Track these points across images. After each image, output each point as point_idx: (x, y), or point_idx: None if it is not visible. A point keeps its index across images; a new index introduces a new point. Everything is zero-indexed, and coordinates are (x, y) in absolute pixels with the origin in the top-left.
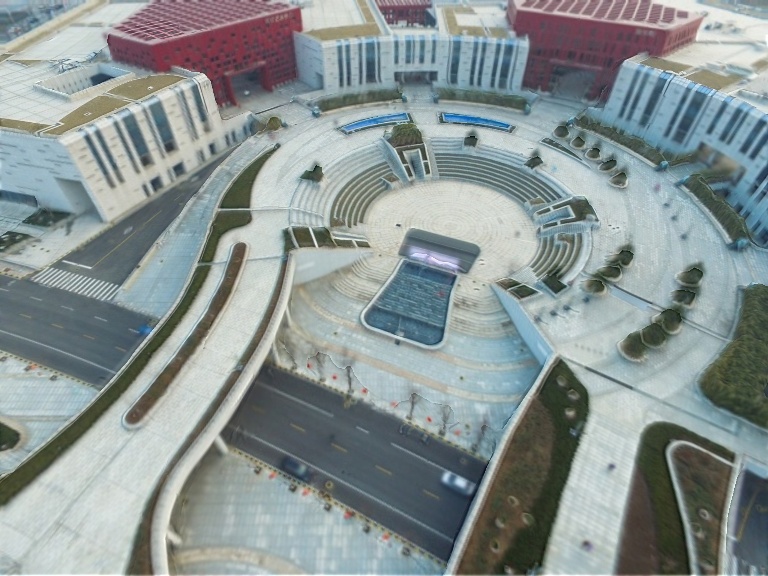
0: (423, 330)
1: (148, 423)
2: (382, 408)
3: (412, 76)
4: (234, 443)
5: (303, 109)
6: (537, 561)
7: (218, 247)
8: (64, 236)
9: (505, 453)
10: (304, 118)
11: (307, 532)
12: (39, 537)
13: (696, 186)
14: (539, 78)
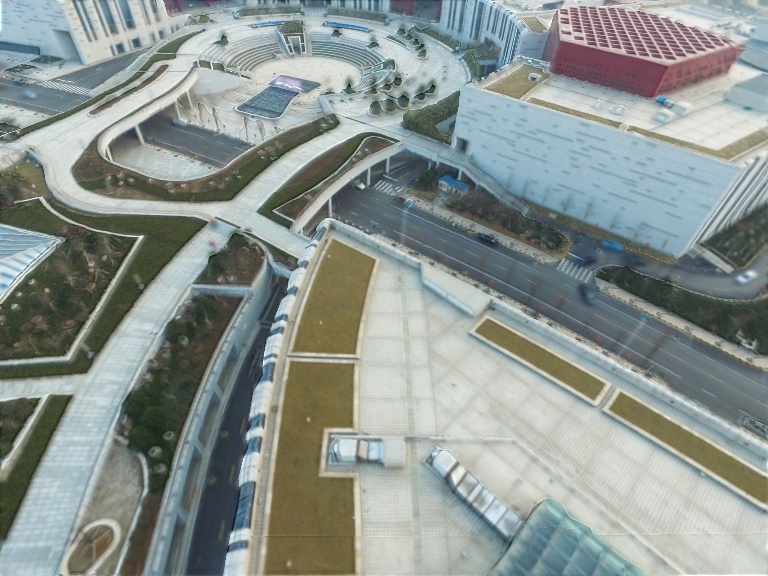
0: (271, 114)
1: (101, 115)
2: (234, 137)
3: (314, 1)
4: (149, 141)
5: (229, 15)
6: (278, 156)
7: (152, 66)
8: (58, 69)
9: (282, 134)
10: (228, 19)
11: (180, 167)
12: (45, 142)
13: (467, 57)
14: (405, 6)
